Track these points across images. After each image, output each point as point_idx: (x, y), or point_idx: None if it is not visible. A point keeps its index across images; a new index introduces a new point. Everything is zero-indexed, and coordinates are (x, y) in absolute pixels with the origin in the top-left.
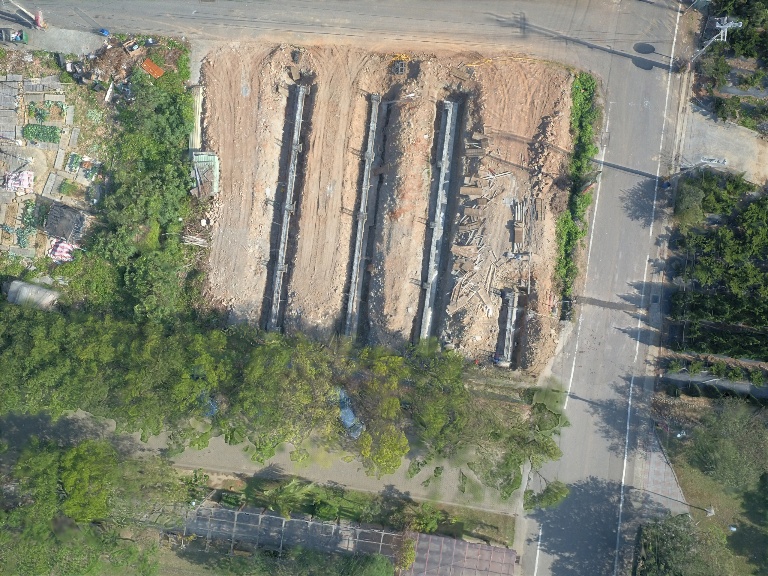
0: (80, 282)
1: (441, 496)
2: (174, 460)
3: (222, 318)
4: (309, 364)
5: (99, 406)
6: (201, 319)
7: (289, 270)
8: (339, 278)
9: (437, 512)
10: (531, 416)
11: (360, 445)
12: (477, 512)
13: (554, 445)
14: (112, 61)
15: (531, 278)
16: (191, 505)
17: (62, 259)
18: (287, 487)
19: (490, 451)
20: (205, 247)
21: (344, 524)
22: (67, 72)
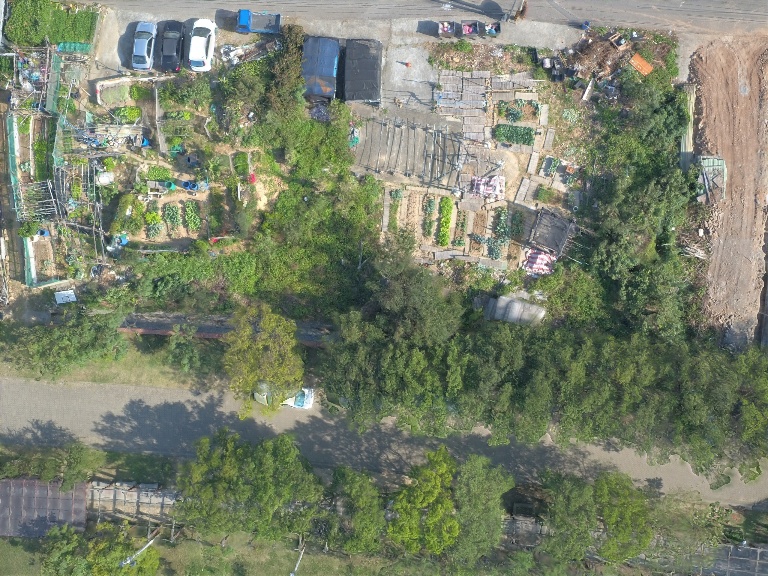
0: (563, 297)
1: None
2: (664, 491)
3: (718, 336)
4: None
5: None
6: (698, 337)
7: None
8: None
9: None
10: None
11: None
12: None
13: None
14: (597, 56)
15: None
16: (713, 542)
17: (539, 272)
18: None
19: None
20: (704, 259)
21: None
22: (543, 68)
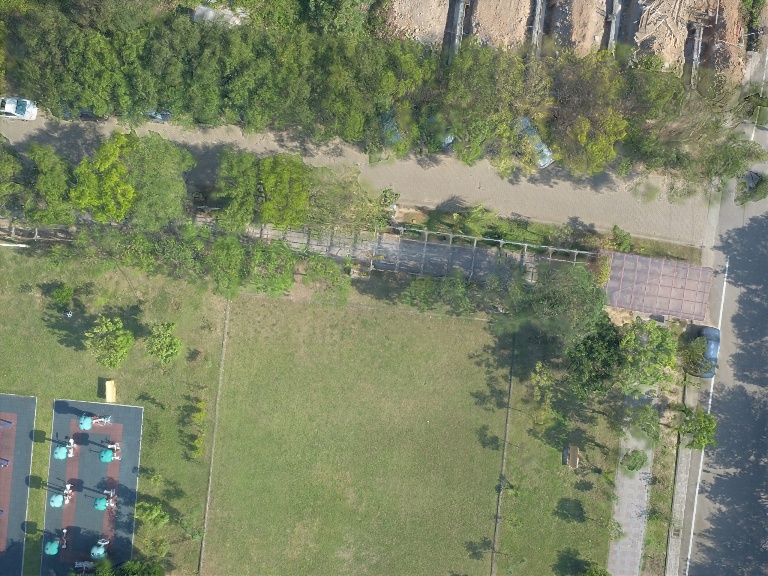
0: (262, 13)
1: (626, 228)
2: None
3: None
4: (517, 60)
5: (303, 104)
6: None
7: (472, 4)
8: (523, 10)
9: (629, 234)
10: (749, 100)
11: (576, 130)
12: (663, 244)
13: (760, 148)
14: None
15: (719, 7)
16: (382, 223)
17: None
18: (475, 211)
19: (677, 181)
20: None
21: (528, 256)
22: None
